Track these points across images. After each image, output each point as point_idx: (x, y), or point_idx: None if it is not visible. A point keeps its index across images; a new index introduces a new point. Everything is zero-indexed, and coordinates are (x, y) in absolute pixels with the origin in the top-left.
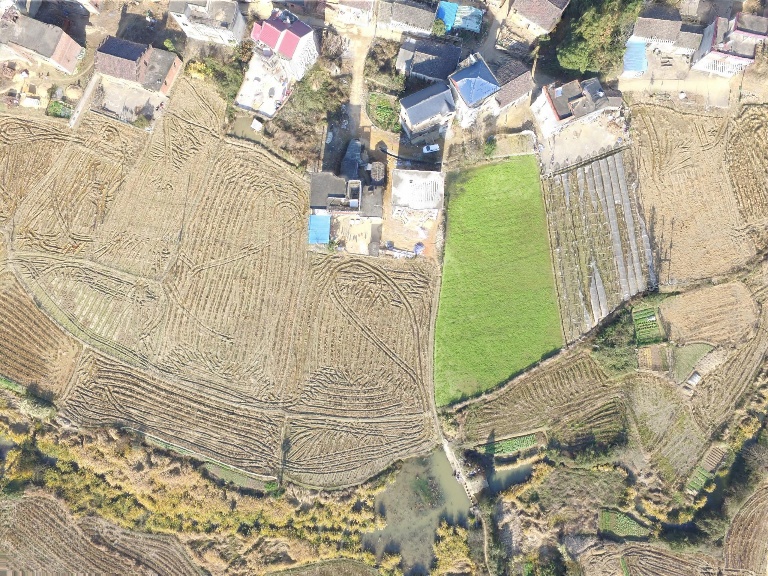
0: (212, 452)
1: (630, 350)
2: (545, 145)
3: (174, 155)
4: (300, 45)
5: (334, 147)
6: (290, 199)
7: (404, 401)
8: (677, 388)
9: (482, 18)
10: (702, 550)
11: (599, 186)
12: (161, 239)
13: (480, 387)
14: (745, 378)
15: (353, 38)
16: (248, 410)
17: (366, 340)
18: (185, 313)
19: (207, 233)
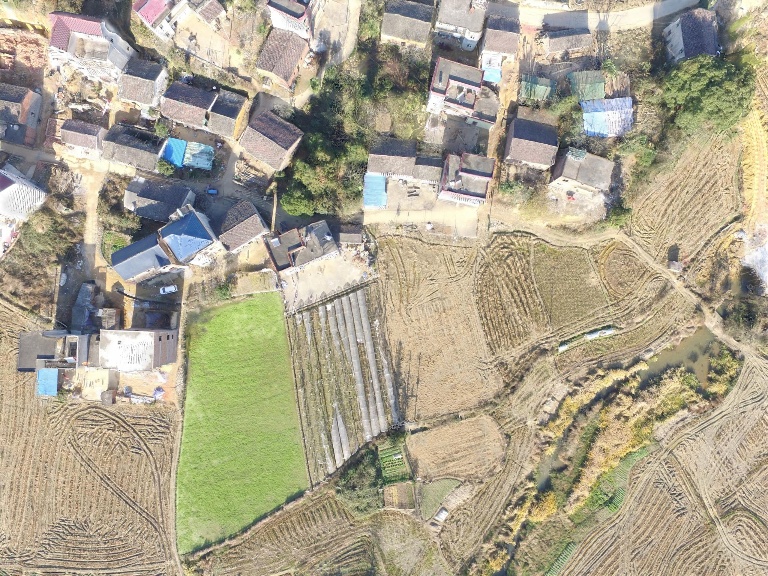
0: None
1: (371, 492)
2: (288, 282)
3: None
4: None
5: (69, 289)
6: None
7: (145, 550)
8: (424, 525)
9: (215, 153)
10: None
11: (341, 325)
12: None
13: (223, 533)
14: (494, 511)
15: (85, 174)
16: None
17: (105, 490)
18: None
19: None
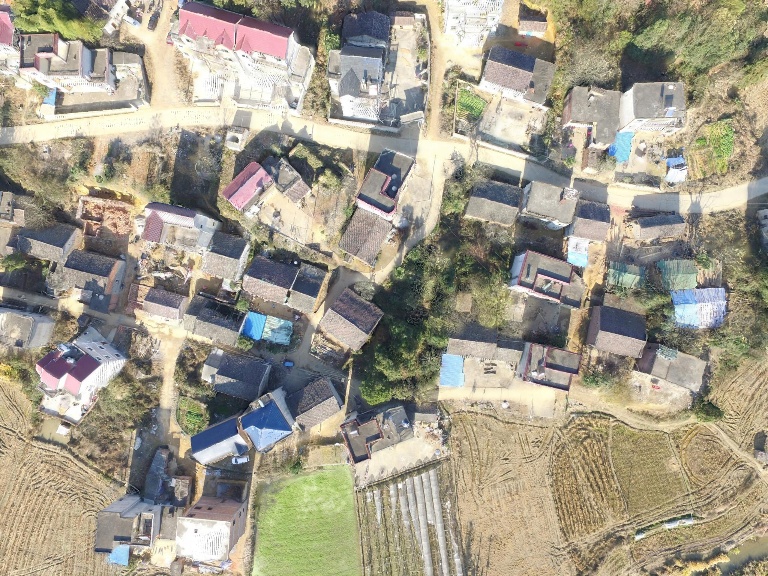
0: None
1: None
2: None
3: None
4: (86, 383)
5: (143, 453)
6: (96, 508)
7: None
8: None
9: (293, 327)
10: None
11: (412, 505)
12: None
13: None
14: None
15: (164, 339)
16: None
17: None
18: None
19: (11, 541)
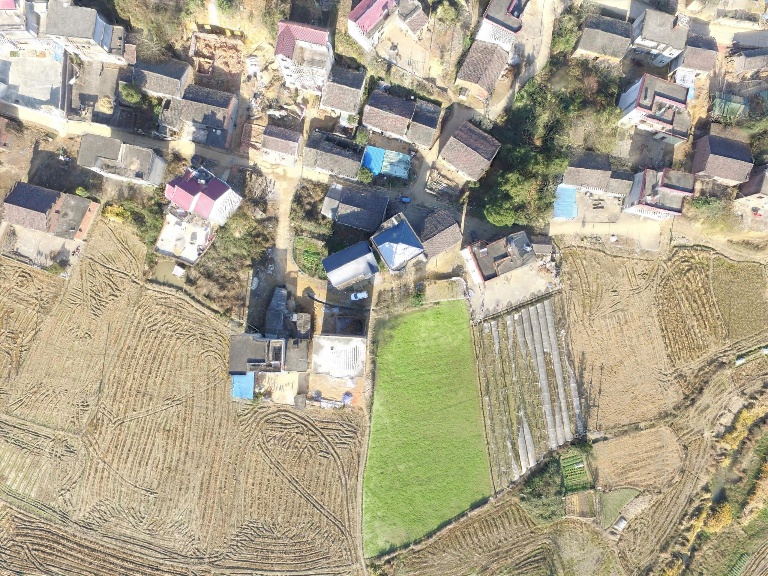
0: None
1: (557, 500)
2: (475, 290)
3: (92, 302)
4: (216, 205)
5: (260, 293)
6: (214, 348)
7: (332, 553)
8: (603, 533)
9: (411, 162)
10: None
11: (528, 334)
12: (80, 391)
13: (408, 537)
14: (670, 521)
15: (279, 179)
16: (173, 566)
17: (293, 492)
18: (106, 467)
19: (128, 384)
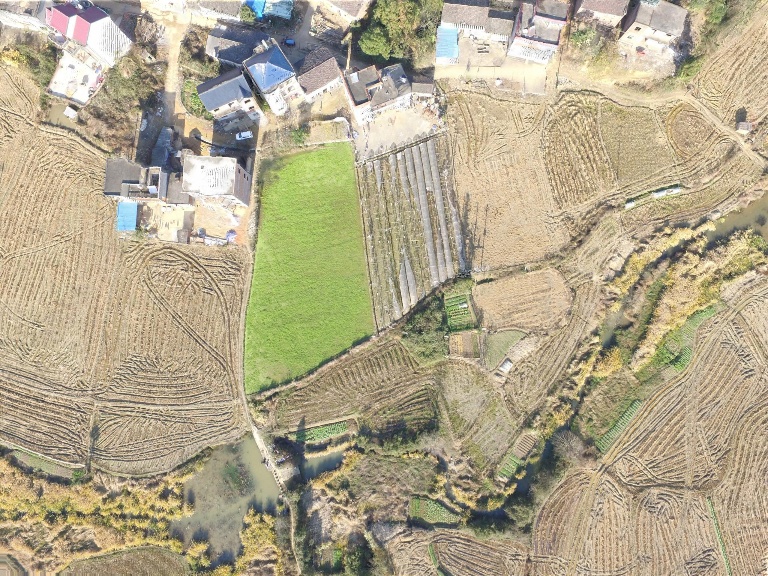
0: (21, 440)
1: (437, 337)
2: (360, 132)
3: None
4: (94, 31)
5: (148, 134)
6: (103, 186)
7: (213, 388)
8: (488, 375)
9: (294, 5)
10: (509, 537)
11: (410, 173)
12: None
13: (290, 374)
14: (558, 365)
15: (169, 25)
16: (57, 398)
17: (176, 327)
18: None
19: (20, 221)
